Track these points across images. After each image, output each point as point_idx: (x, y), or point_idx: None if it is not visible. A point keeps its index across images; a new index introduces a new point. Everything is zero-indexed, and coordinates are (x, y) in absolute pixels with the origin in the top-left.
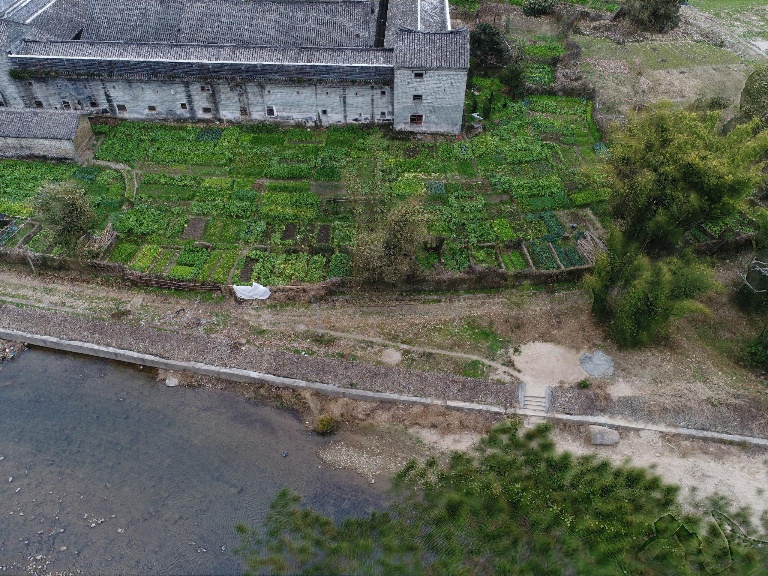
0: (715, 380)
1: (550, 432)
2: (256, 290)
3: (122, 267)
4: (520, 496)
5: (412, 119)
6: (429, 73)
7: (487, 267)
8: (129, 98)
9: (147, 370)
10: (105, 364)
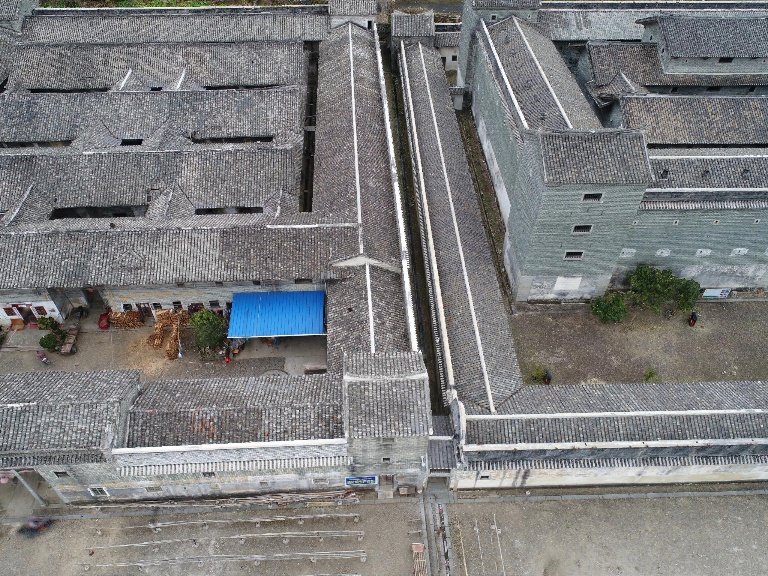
0: None
1: None
2: None
3: None
4: None
5: None
6: None
7: None
8: None
9: None
10: None
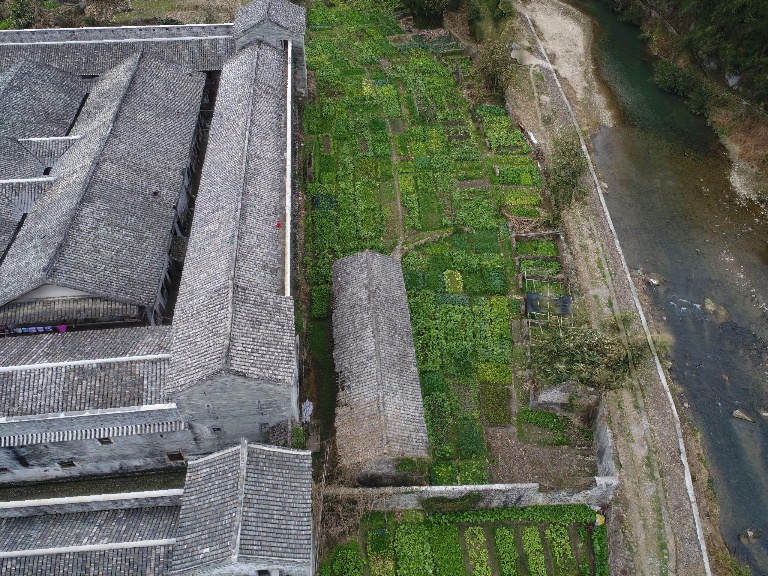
0: (509, 21)
1: None
2: None
3: None
4: None
5: None
6: None
7: (480, 52)
8: None
9: None
10: None
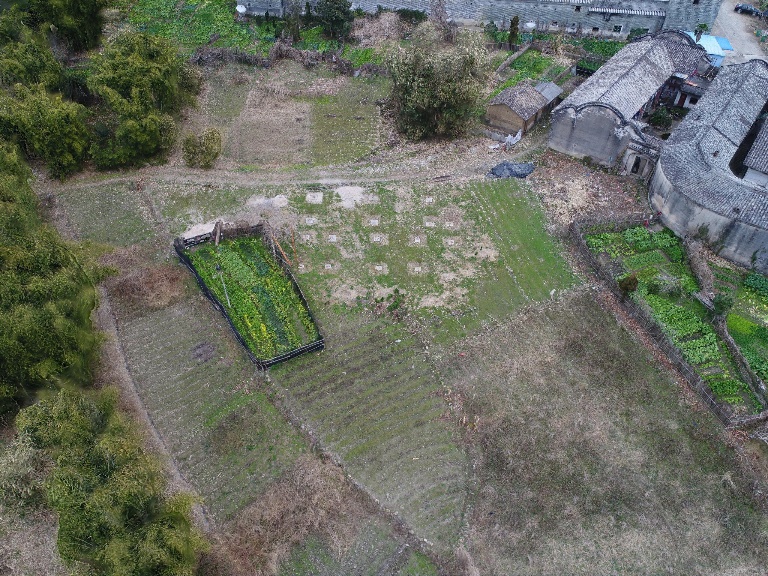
0: None
1: None
2: None
3: None
4: None
5: None
6: None
7: None
8: None
9: None
10: None
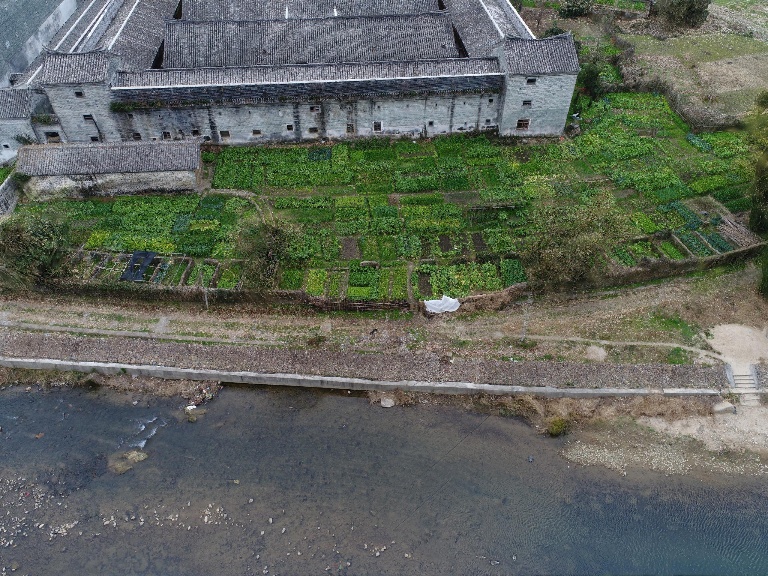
0: None
1: (766, 407)
2: (446, 303)
3: (305, 294)
4: (763, 469)
5: (519, 124)
6: (541, 78)
7: (661, 258)
8: (234, 123)
9: (355, 394)
10: (311, 393)
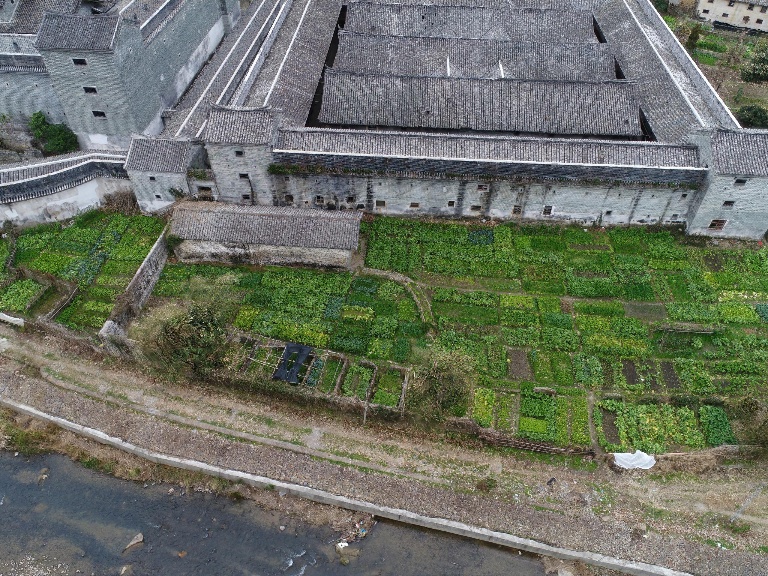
0: None
1: None
2: (640, 459)
3: (476, 425)
4: None
5: (712, 224)
6: (753, 180)
7: None
8: (393, 194)
9: (527, 557)
10: (475, 547)
